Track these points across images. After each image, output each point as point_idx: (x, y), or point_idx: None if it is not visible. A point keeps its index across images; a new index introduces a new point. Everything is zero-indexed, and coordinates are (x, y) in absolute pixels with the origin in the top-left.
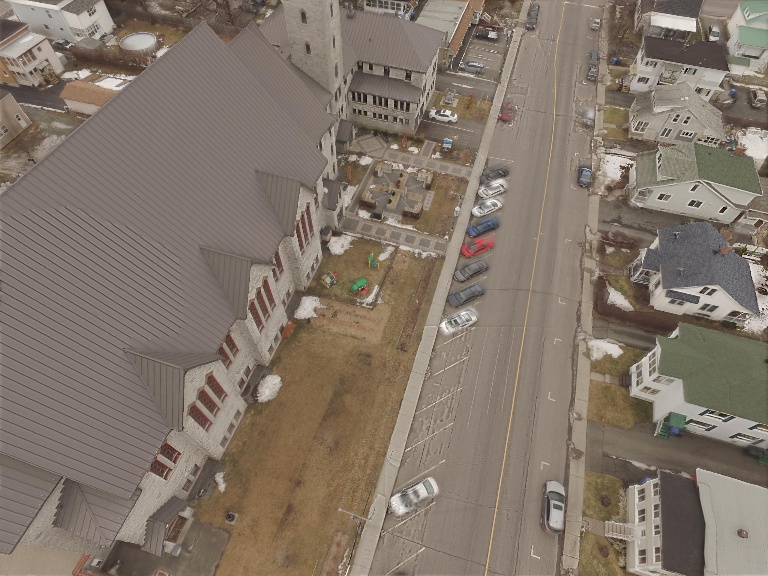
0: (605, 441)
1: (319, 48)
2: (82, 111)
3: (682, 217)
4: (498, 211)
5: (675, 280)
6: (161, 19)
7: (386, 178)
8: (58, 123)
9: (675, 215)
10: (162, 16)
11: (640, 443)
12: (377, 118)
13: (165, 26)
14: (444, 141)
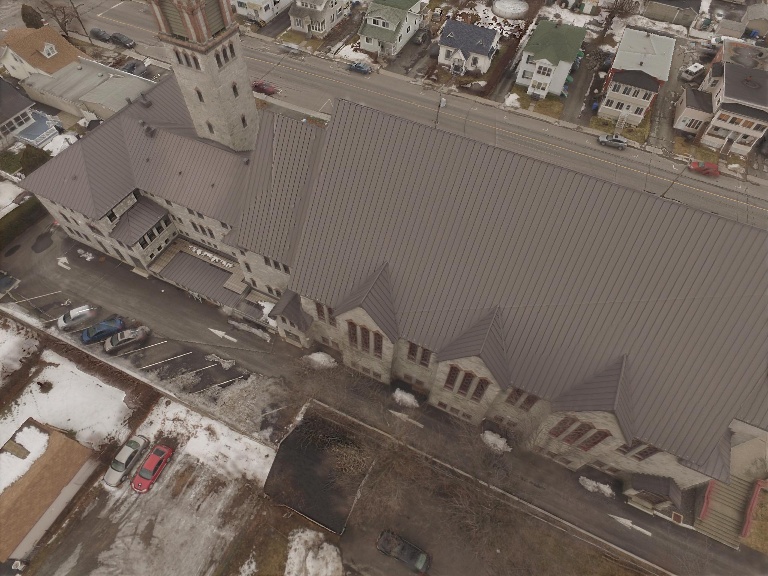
0: (571, 116)
1: (252, 112)
2: (44, 530)
3: (409, 43)
4: None
5: (484, 48)
6: None
7: None
8: None
9: (406, 45)
10: None
11: (571, 104)
12: None
13: None
14: None
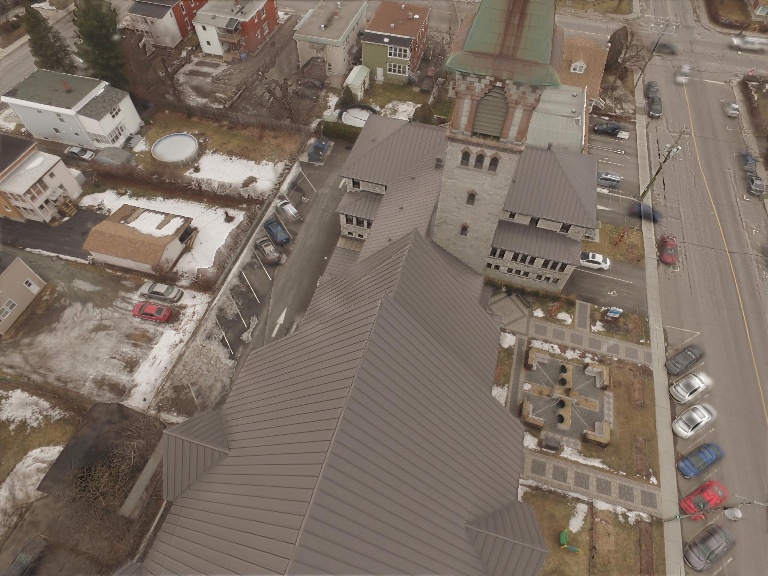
0: None
1: (482, 231)
2: (113, 263)
3: None
4: (708, 426)
5: None
6: (199, 112)
7: (541, 370)
8: (81, 282)
9: None
10: (201, 109)
11: None
12: (512, 273)
13: (205, 120)
14: (610, 310)
